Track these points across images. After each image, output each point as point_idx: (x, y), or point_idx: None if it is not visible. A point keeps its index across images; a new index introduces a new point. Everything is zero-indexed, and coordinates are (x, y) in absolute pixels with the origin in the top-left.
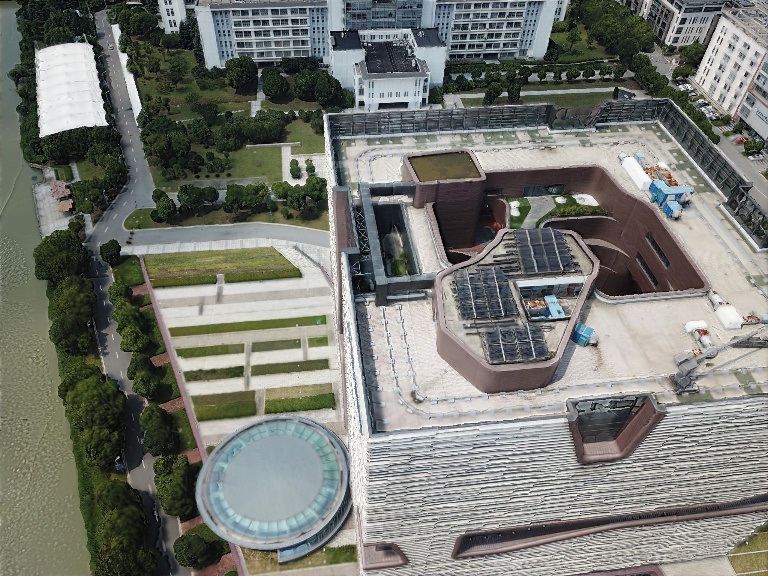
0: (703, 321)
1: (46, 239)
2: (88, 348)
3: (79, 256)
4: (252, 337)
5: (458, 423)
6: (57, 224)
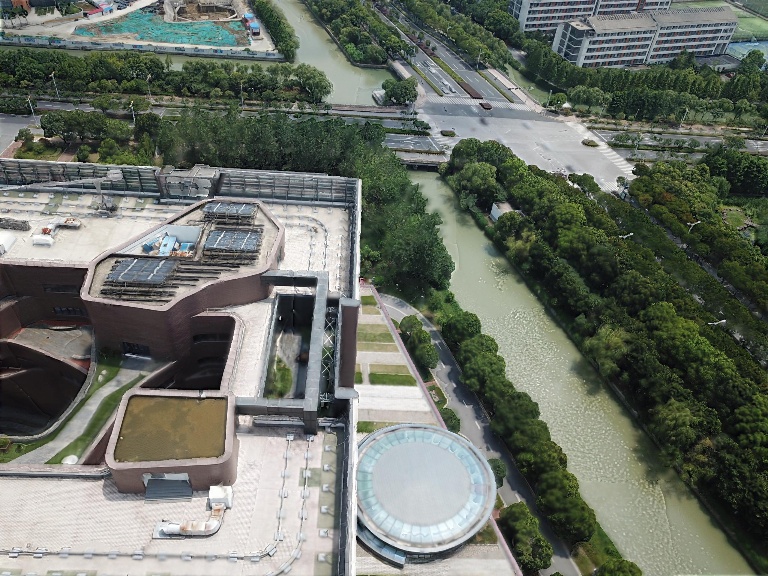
0: (35, 237)
1: None
2: None
3: None
4: None
5: (290, 213)
6: None
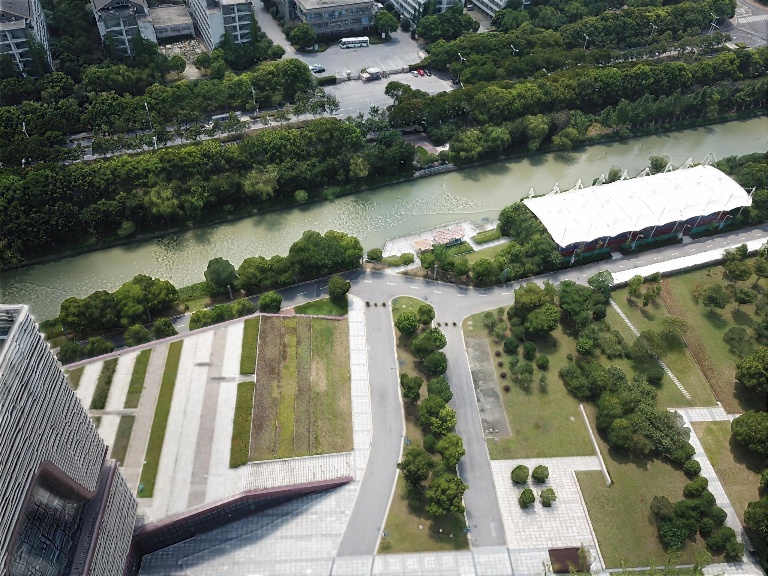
0: None
1: (340, 233)
2: (220, 297)
3: (310, 259)
4: (144, 415)
5: None
6: (404, 247)
